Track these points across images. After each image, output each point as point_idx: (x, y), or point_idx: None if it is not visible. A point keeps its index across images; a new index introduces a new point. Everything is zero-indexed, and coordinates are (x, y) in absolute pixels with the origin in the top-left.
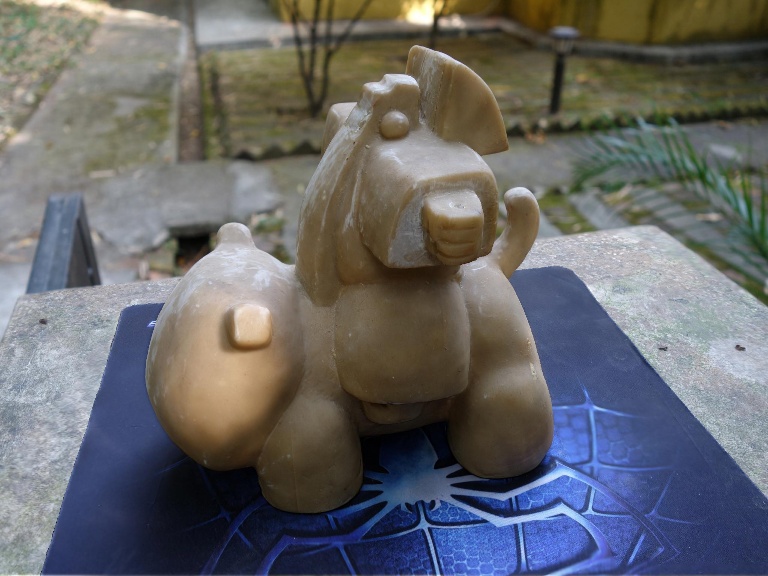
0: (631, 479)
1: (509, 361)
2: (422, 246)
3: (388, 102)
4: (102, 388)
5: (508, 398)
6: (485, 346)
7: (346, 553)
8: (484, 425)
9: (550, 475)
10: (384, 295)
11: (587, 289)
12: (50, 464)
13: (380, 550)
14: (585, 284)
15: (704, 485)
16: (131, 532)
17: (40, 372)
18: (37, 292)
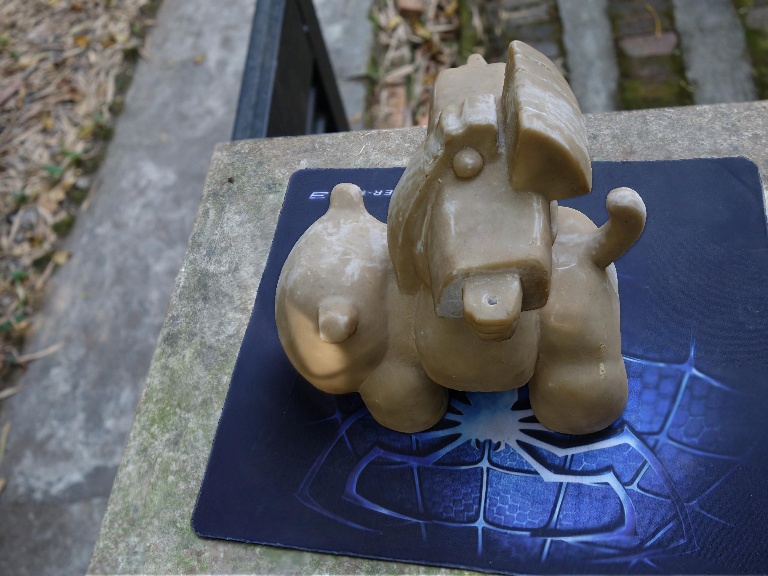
0: (690, 462)
1: (577, 361)
2: None
3: (460, 141)
4: (267, 267)
5: (570, 391)
6: (554, 348)
7: (417, 474)
8: (547, 403)
9: (613, 440)
10: None
11: (762, 200)
12: (227, 338)
13: (444, 478)
14: (763, 192)
15: (762, 487)
16: (273, 416)
17: (226, 239)
18: (229, 141)
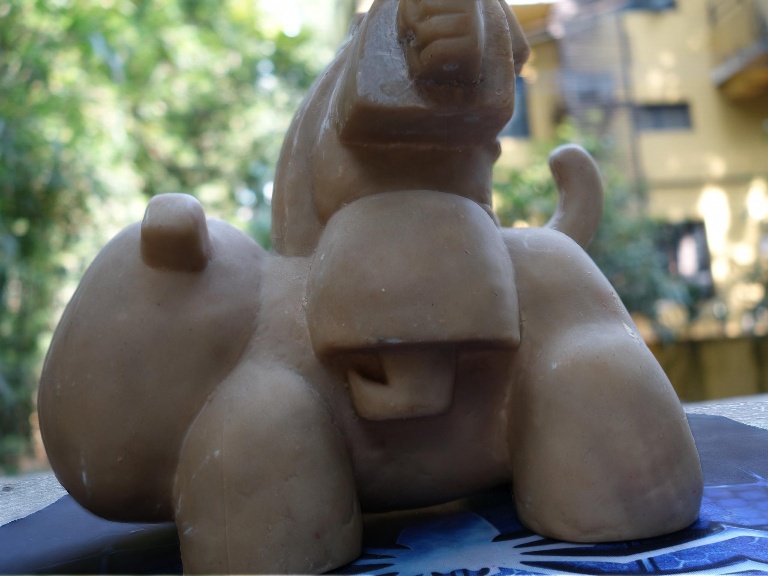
0: None
1: (586, 315)
2: (405, 74)
3: None
4: (28, 518)
5: (593, 362)
6: (541, 291)
7: None
8: (561, 416)
9: (714, 536)
10: (371, 196)
11: (729, 419)
12: None
13: None
14: None
15: None
16: None
17: None
18: None
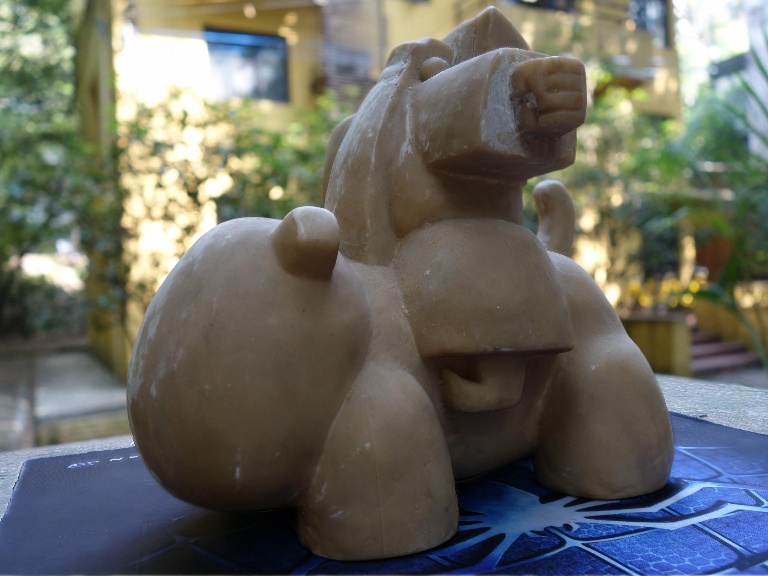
0: None
1: (605, 328)
2: (513, 127)
3: (425, 51)
4: (9, 514)
5: (621, 365)
6: (575, 307)
7: None
8: (601, 406)
9: (689, 489)
10: (462, 222)
11: None
12: None
13: (533, 571)
14: None
15: None
16: None
17: None
18: None
